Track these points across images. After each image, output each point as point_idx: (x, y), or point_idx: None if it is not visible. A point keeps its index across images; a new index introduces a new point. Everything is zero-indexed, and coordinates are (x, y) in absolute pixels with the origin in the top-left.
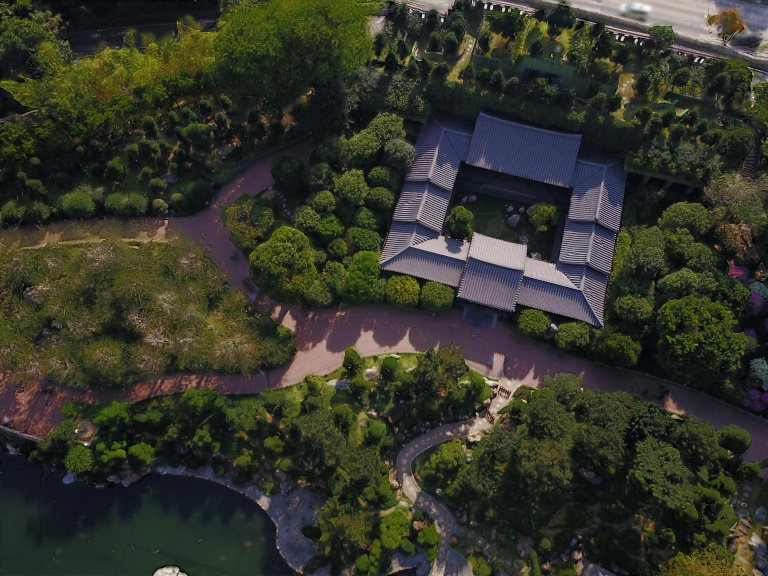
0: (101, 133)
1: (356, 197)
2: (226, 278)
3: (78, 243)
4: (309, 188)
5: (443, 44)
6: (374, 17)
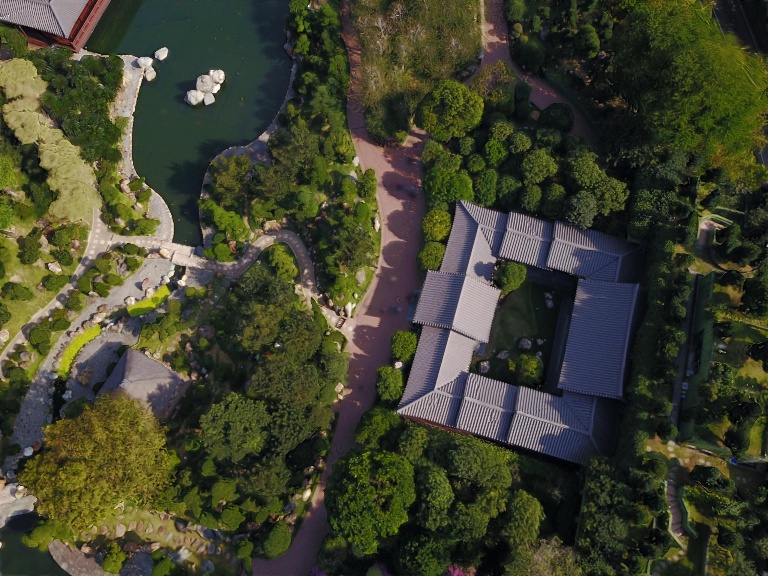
0: None
1: (524, 167)
2: None
3: None
4: None
5: None
6: None
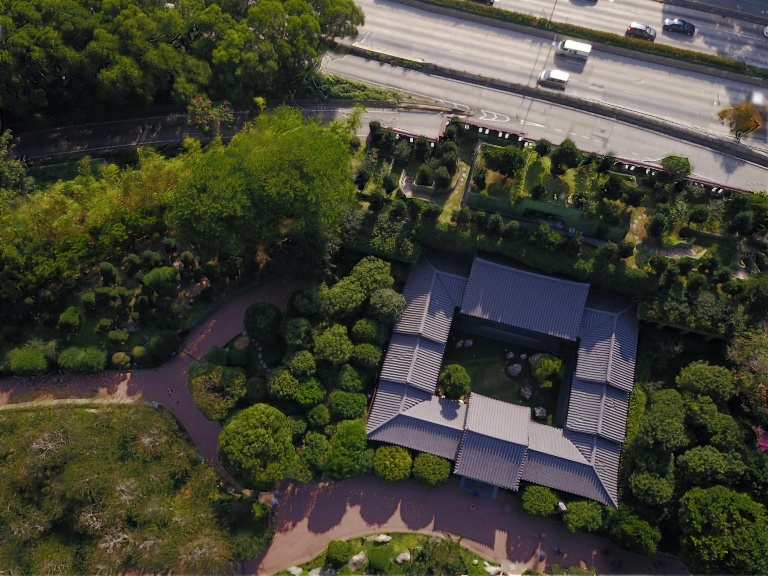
0: (54, 277)
1: (339, 360)
2: (194, 455)
3: (28, 406)
4: (286, 343)
5: (434, 177)
6: (359, 109)
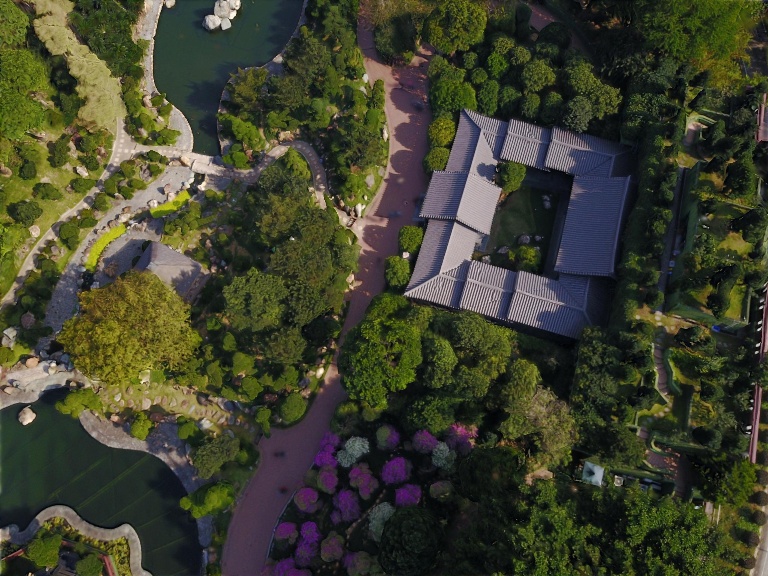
0: None
1: (524, 75)
2: None
3: None
4: None
5: None
6: None
